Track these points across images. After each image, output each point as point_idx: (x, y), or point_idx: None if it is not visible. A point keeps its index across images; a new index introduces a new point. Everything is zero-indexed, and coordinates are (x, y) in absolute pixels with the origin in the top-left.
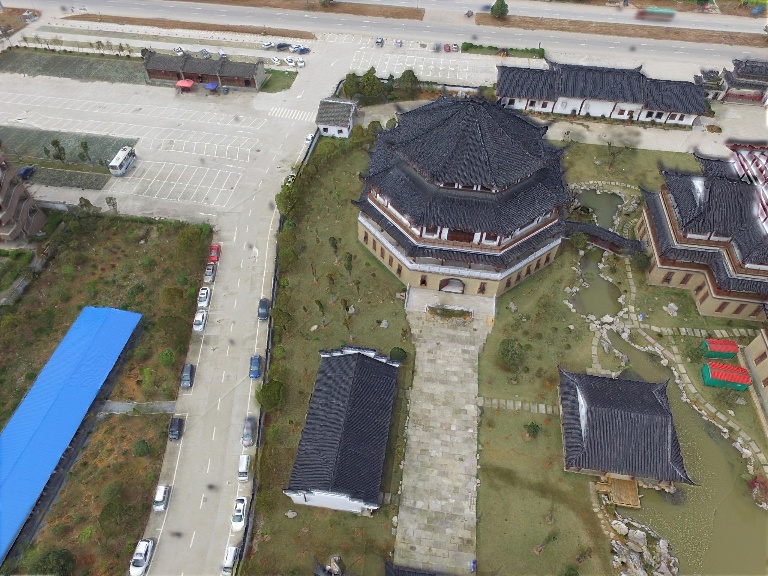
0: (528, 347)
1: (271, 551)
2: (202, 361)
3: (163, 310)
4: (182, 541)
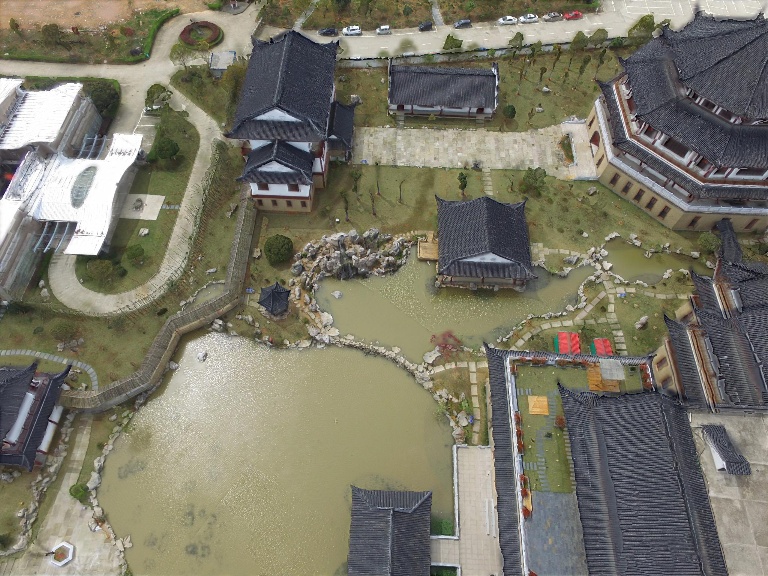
0: (549, 200)
1: (362, 76)
2: (476, 30)
3: (510, 4)
4: (362, 44)
